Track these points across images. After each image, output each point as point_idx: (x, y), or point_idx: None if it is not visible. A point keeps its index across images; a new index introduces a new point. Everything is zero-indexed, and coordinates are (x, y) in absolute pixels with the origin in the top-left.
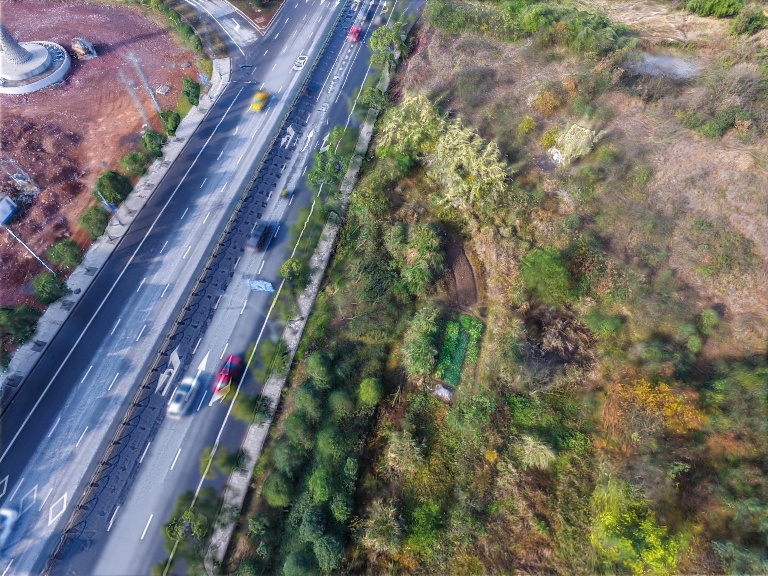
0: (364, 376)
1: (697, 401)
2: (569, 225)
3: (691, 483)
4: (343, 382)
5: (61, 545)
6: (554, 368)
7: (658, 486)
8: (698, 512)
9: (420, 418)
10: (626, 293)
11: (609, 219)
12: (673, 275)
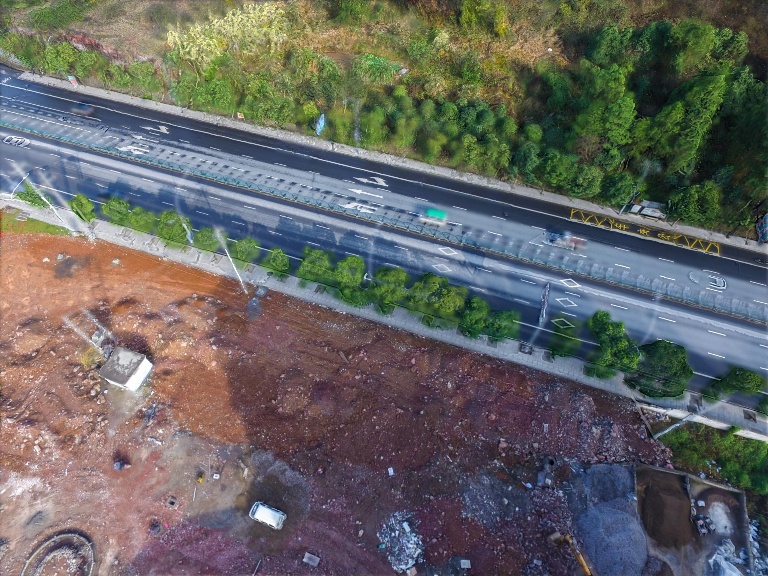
0: (388, 101)
1: None
2: None
3: None
4: None
5: (469, 245)
6: None
7: None
8: None
9: (417, 80)
10: None
11: None
12: None
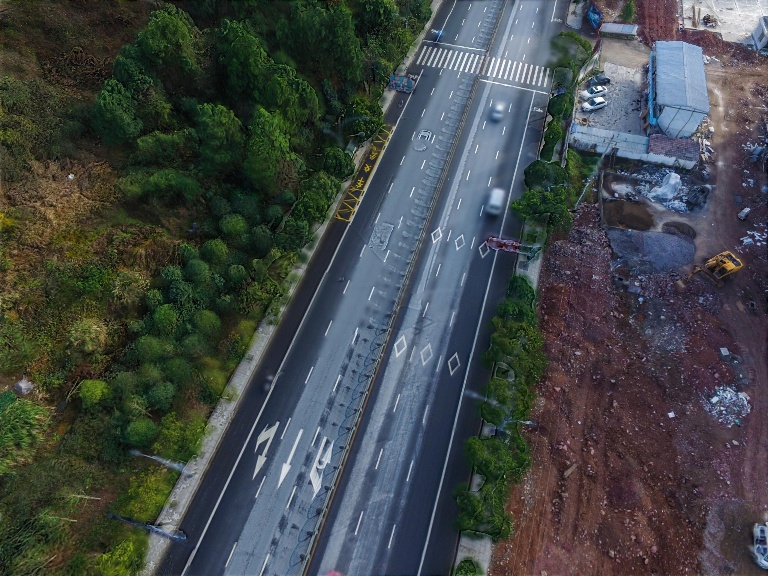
0: (99, 414)
1: None
2: None
3: None
4: (119, 404)
5: (390, 322)
6: None
7: None
8: None
9: (62, 363)
10: None
11: None
12: None
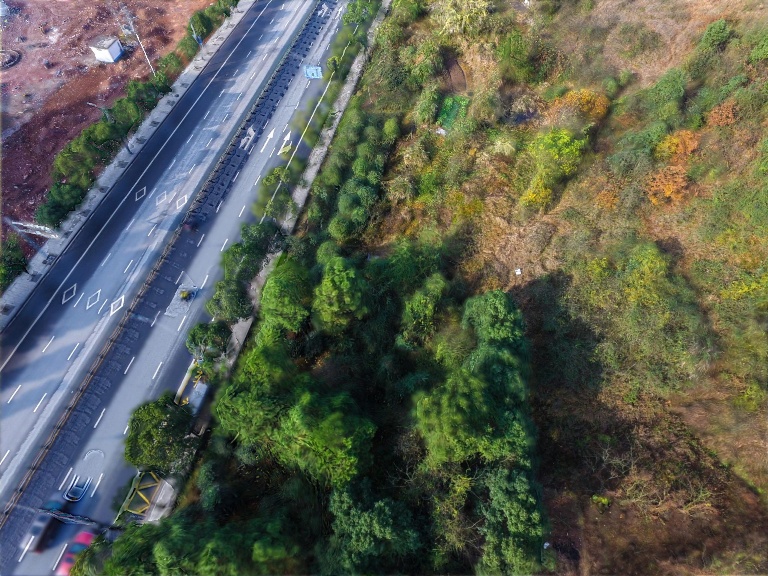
0: None
1: (604, 97)
2: (532, 33)
3: (596, 137)
4: None
5: (187, 218)
6: (519, 121)
7: (574, 132)
8: (600, 152)
9: None
10: (570, 70)
11: (562, 33)
12: (605, 62)
